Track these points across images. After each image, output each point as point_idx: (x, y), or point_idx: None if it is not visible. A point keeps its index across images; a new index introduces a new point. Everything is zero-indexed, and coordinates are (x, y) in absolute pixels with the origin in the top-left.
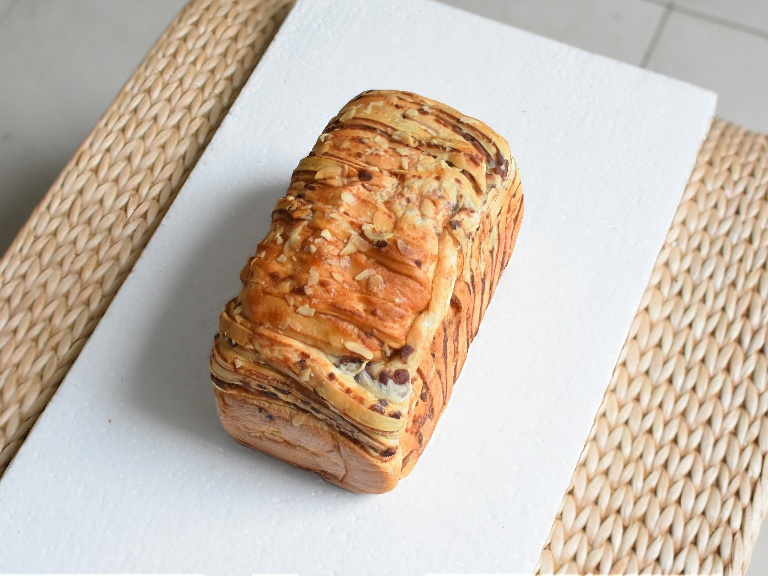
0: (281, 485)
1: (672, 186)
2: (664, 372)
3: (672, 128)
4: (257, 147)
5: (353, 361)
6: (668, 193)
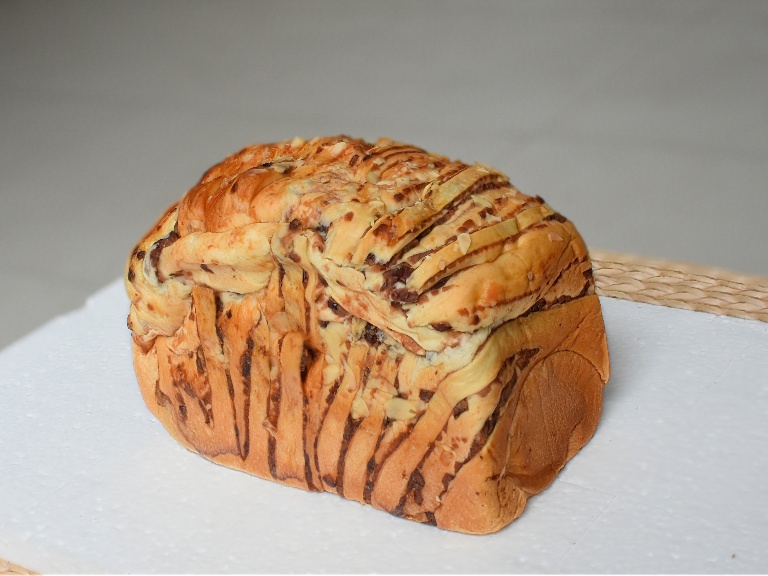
0: None
1: None
2: None
3: None
4: (662, 336)
5: None
6: None
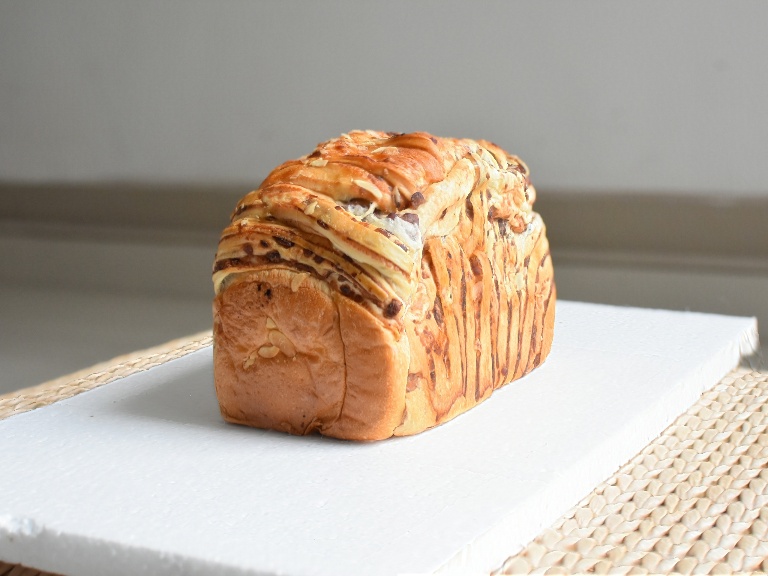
0: (270, 441)
1: (714, 344)
2: (720, 435)
3: (711, 328)
4: None
5: (361, 205)
6: (710, 346)
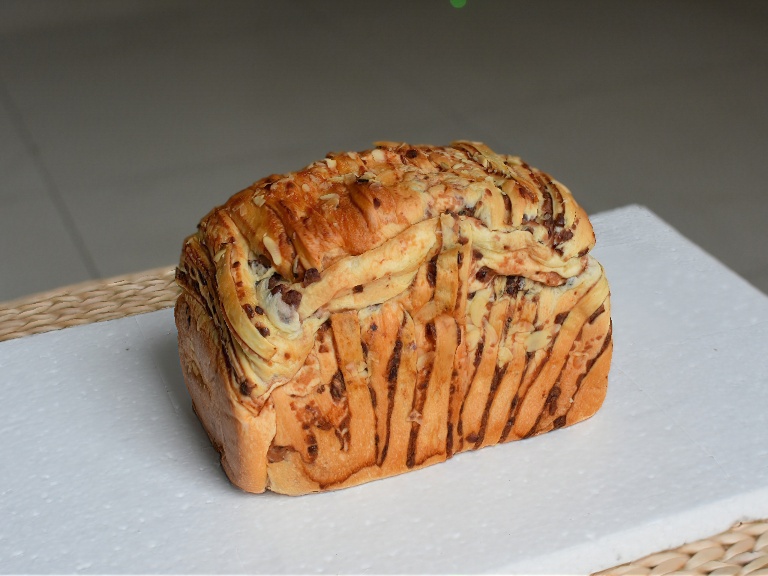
0: (186, 449)
1: None
2: None
3: None
4: None
5: (265, 265)
6: None
